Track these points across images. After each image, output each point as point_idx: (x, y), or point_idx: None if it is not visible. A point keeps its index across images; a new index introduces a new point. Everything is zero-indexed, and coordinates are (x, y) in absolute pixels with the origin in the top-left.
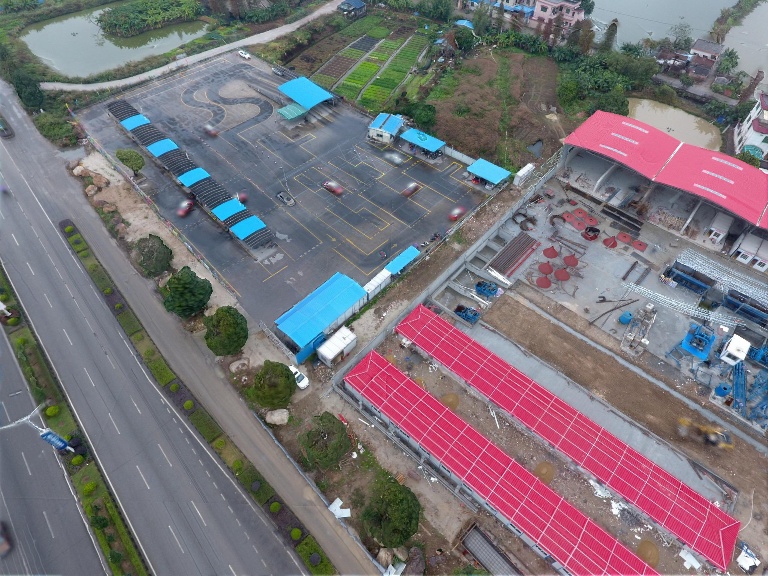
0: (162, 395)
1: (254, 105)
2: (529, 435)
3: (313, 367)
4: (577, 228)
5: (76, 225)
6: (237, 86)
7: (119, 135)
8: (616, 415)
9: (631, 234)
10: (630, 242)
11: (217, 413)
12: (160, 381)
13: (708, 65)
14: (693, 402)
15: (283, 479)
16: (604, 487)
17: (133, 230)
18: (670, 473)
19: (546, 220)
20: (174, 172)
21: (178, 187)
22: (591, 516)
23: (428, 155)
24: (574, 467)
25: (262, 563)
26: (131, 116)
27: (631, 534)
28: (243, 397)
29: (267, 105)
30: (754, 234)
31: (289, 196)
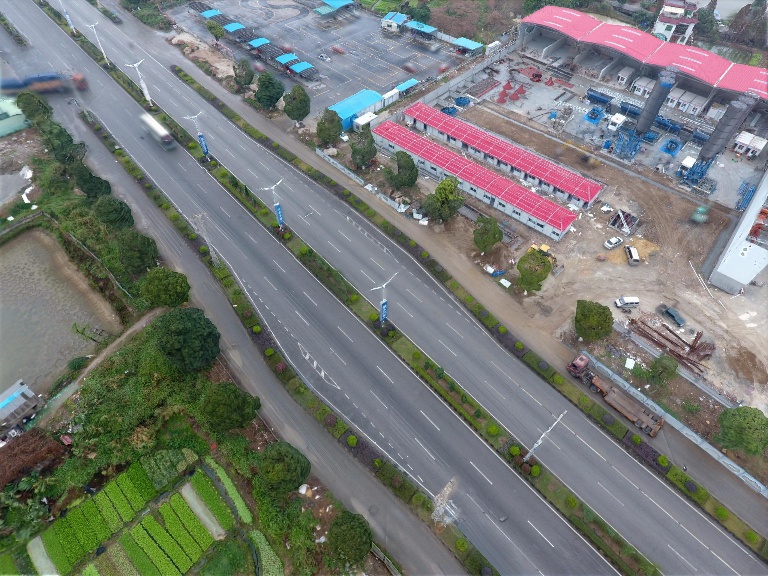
0: (257, 143)
1: (295, 9)
2: (485, 162)
3: (350, 134)
4: (527, 76)
5: (181, 68)
6: None
7: (199, 24)
8: (540, 156)
9: (564, 80)
10: (563, 83)
11: (293, 151)
12: (255, 136)
13: None
14: (590, 153)
15: (336, 177)
16: (528, 181)
17: (221, 72)
18: None
19: (506, 72)
20: (245, 39)
21: (247, 51)
22: None
23: (425, 38)
24: (511, 174)
25: (328, 205)
26: (207, 10)
27: None
28: (308, 145)
29: (304, 9)
30: (647, 77)
31: None
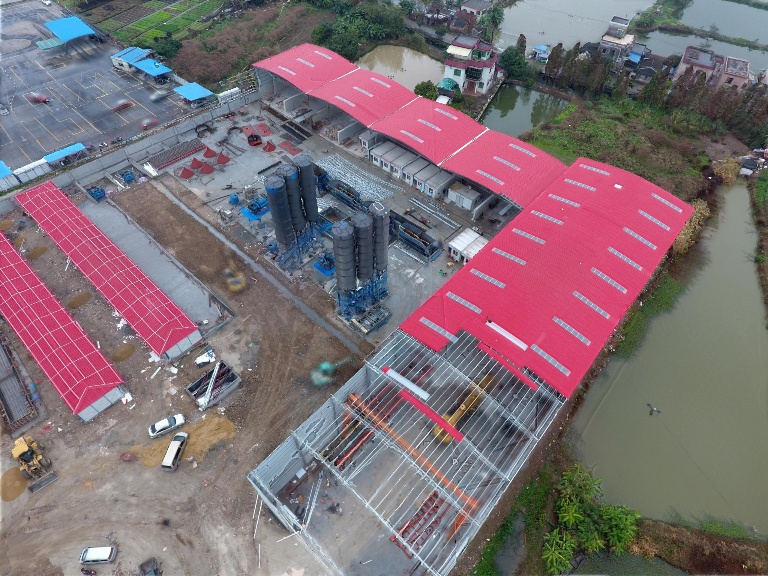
0: None
1: (27, 40)
2: None
3: None
4: None
5: None
6: (22, 26)
7: None
8: (173, 264)
9: (294, 143)
10: (288, 148)
11: None
12: None
13: (466, 18)
14: (250, 258)
15: None
16: None
17: None
18: (186, 302)
19: (225, 130)
20: None
21: None
22: (97, 328)
23: (157, 81)
24: None
25: None
26: None
27: (121, 340)
28: None
29: None
30: (391, 142)
31: (3, 107)
